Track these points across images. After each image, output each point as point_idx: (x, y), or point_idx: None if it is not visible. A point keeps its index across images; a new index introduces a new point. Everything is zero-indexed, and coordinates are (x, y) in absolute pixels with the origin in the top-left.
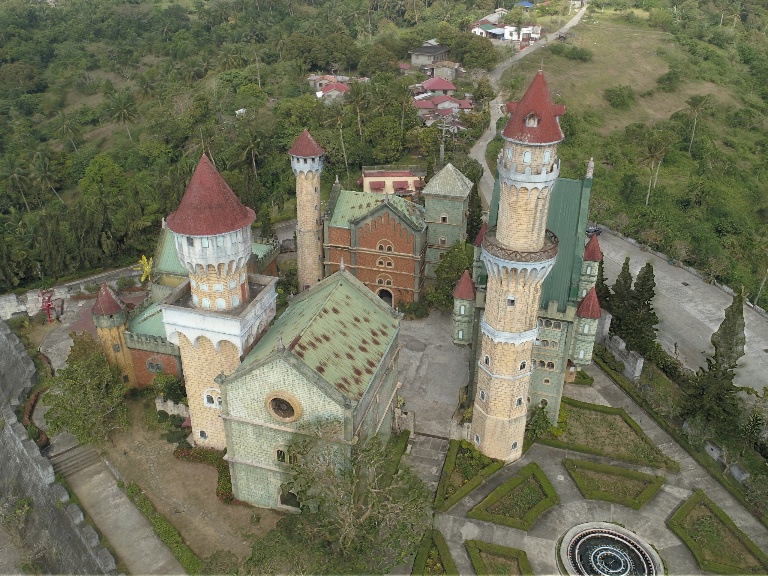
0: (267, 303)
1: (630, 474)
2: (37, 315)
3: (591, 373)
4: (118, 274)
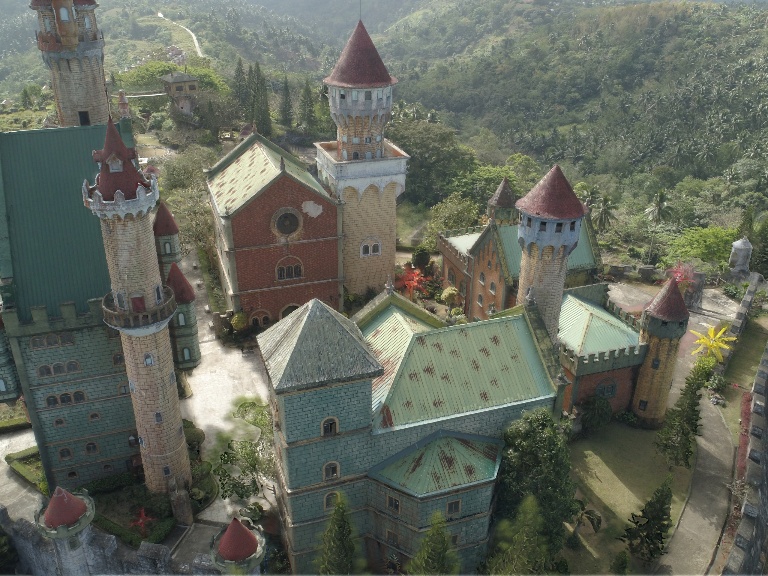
0: None
1: None
2: None
3: (7, 488)
4: None
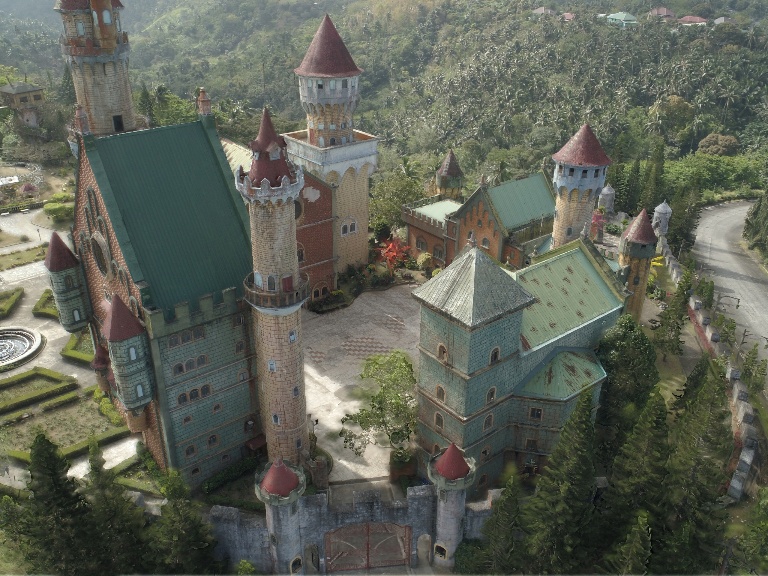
0: (311, 158)
1: (4, 402)
2: (593, 227)
3: None
4: (681, 271)
